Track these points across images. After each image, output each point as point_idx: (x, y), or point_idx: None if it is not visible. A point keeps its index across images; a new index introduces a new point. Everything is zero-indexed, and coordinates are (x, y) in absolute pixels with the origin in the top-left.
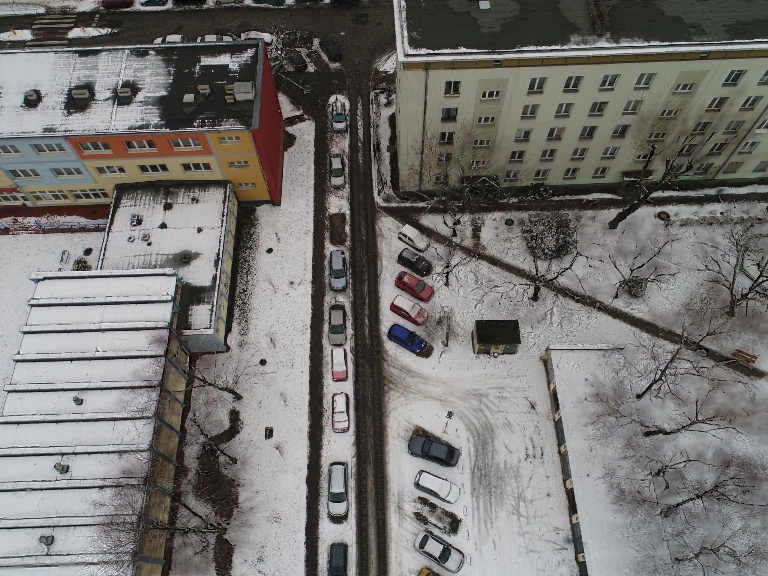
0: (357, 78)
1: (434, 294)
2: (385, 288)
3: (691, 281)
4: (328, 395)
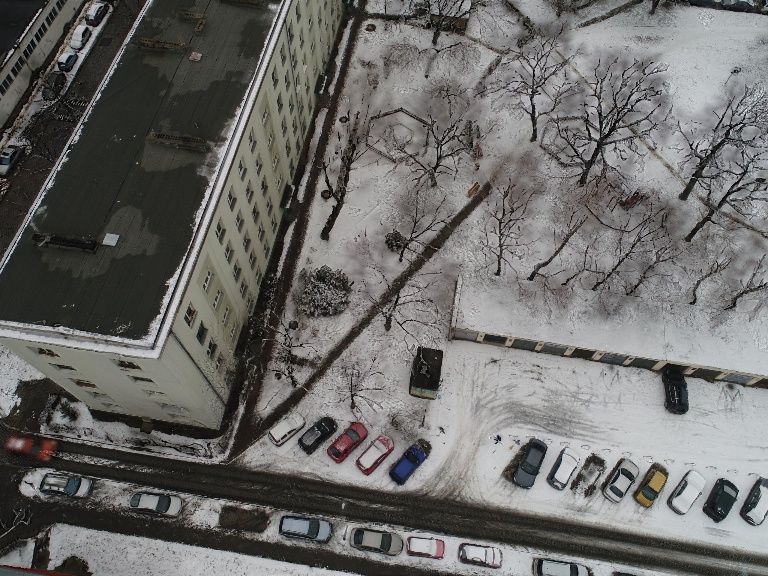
0: (4, 449)
1: (360, 423)
2: (340, 476)
3: (397, 199)
4: (458, 568)
